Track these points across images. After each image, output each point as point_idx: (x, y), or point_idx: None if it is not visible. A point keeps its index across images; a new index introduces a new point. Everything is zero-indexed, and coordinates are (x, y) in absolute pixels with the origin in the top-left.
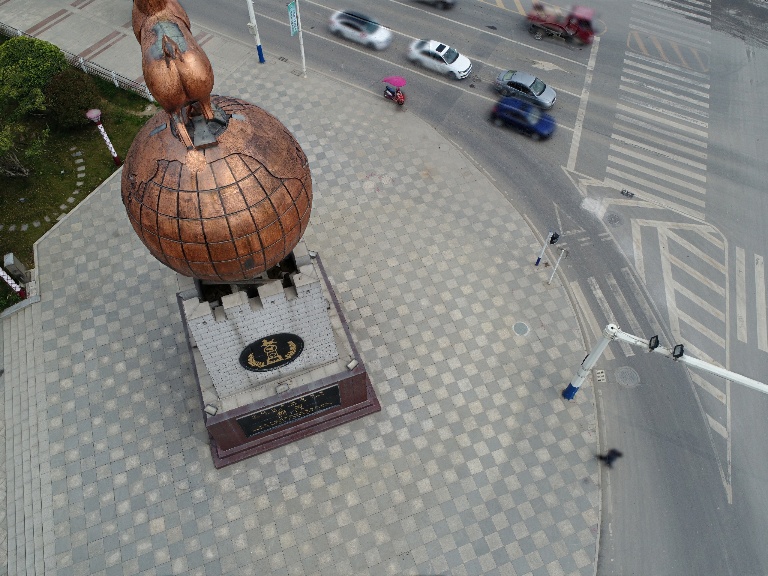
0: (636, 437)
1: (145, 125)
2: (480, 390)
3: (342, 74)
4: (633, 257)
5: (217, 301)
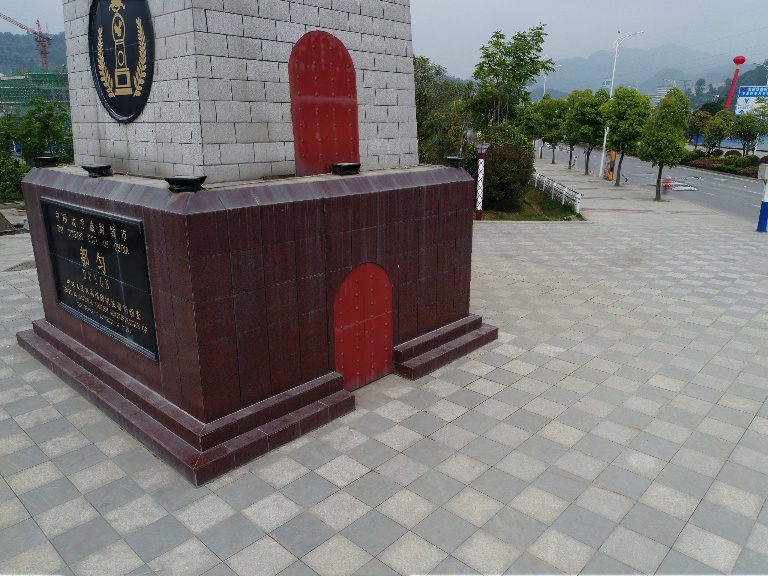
0: None
1: None
2: None
3: None
4: None
5: None
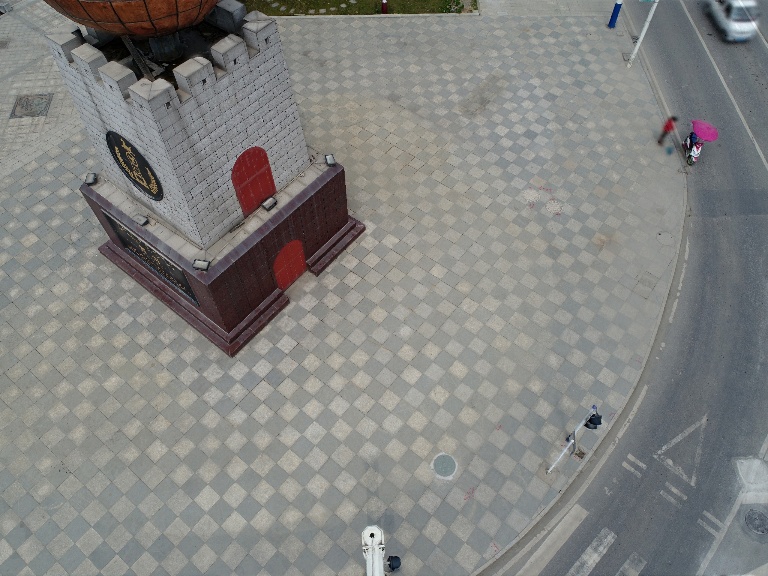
0: None
1: None
2: (318, 455)
3: (672, 92)
4: None
5: None
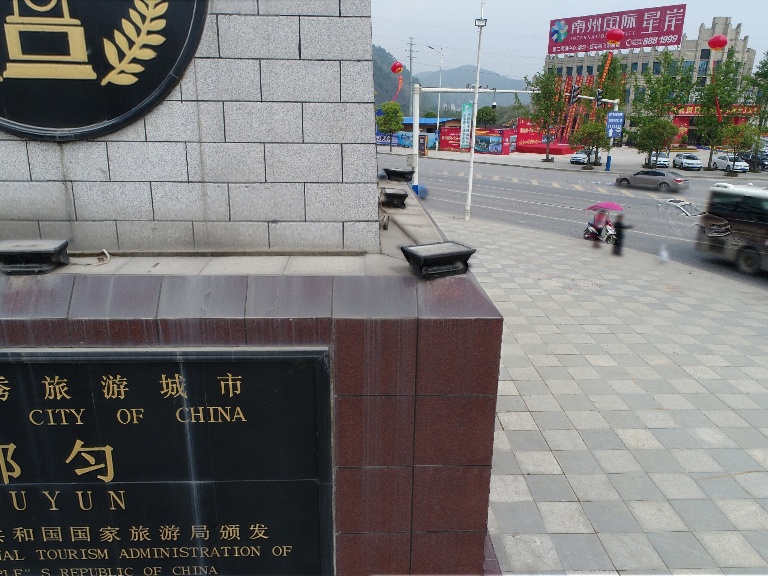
0: None
1: None
2: None
3: (520, 225)
4: None
5: None
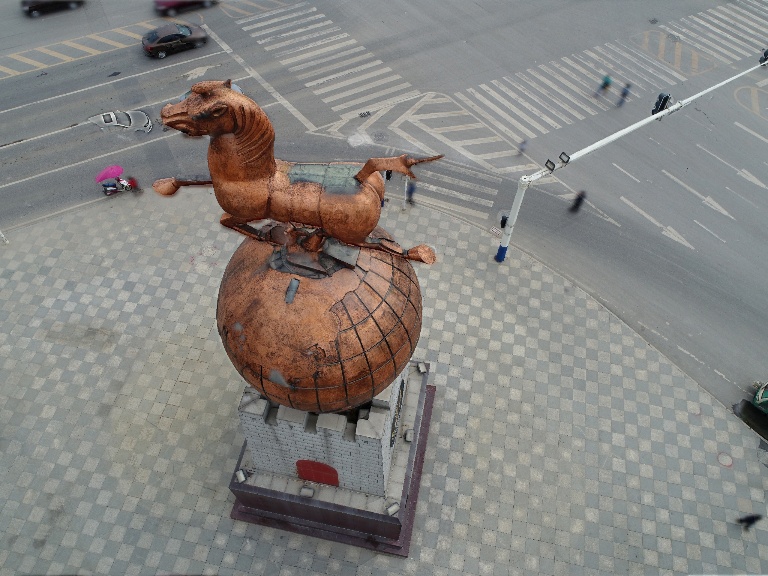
0: (551, 242)
1: (257, 305)
2: (462, 309)
3: (38, 211)
4: (419, 149)
5: (361, 410)
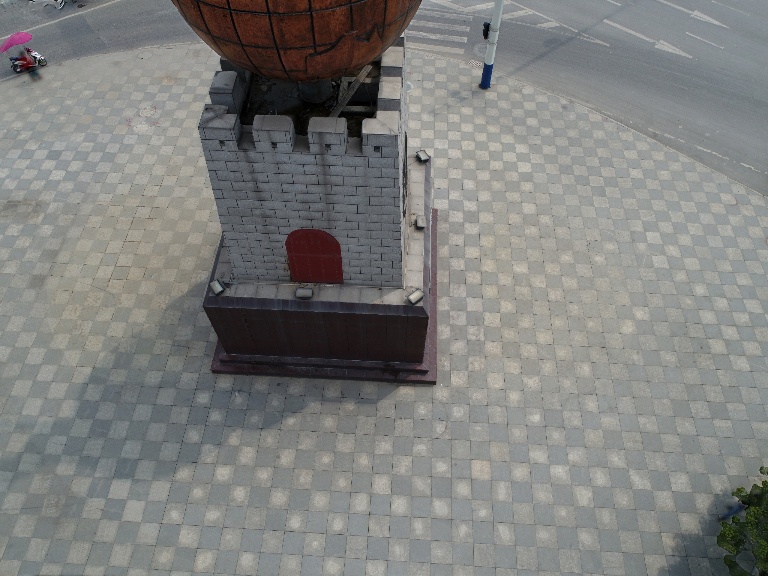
0: (538, 67)
1: None
2: (452, 136)
3: None
4: None
5: None
